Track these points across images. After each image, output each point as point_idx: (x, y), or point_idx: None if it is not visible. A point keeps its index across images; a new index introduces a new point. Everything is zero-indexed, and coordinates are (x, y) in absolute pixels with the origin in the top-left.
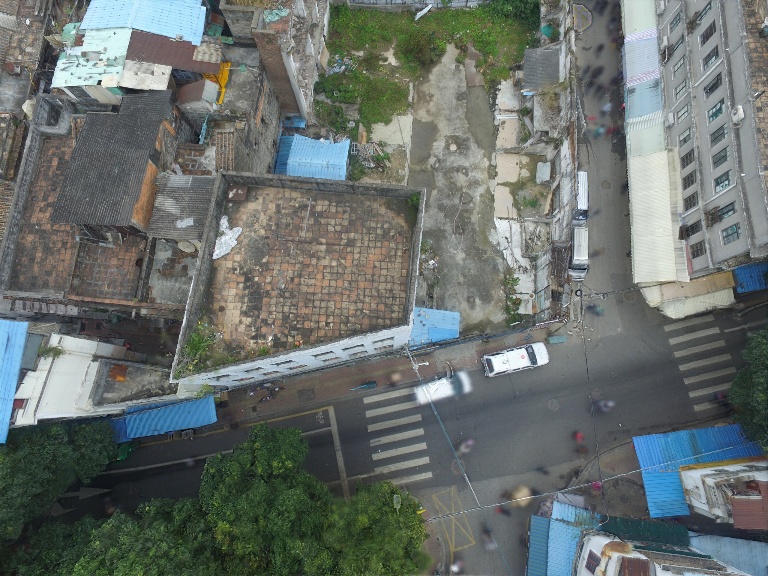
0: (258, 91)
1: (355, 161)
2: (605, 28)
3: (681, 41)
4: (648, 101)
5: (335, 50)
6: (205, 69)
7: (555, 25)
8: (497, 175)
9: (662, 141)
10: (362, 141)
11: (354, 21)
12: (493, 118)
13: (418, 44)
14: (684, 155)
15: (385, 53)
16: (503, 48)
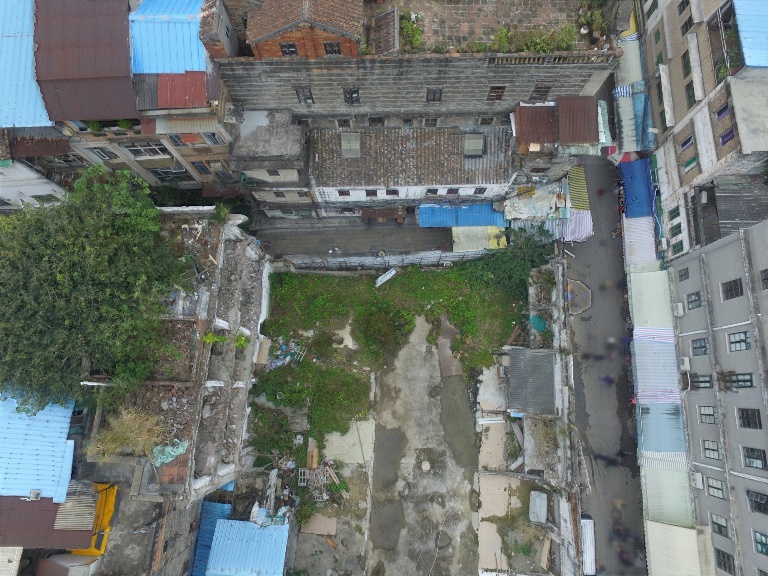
0: (153, 534)
1: (303, 497)
2: (607, 289)
3: (709, 380)
4: (667, 432)
5: (278, 330)
6: (71, 543)
7: (547, 316)
8: (481, 506)
9: (687, 498)
10: (312, 463)
11: (301, 290)
12: (474, 422)
13: (379, 330)
14: (719, 549)
15: (340, 331)
16: (484, 324)
